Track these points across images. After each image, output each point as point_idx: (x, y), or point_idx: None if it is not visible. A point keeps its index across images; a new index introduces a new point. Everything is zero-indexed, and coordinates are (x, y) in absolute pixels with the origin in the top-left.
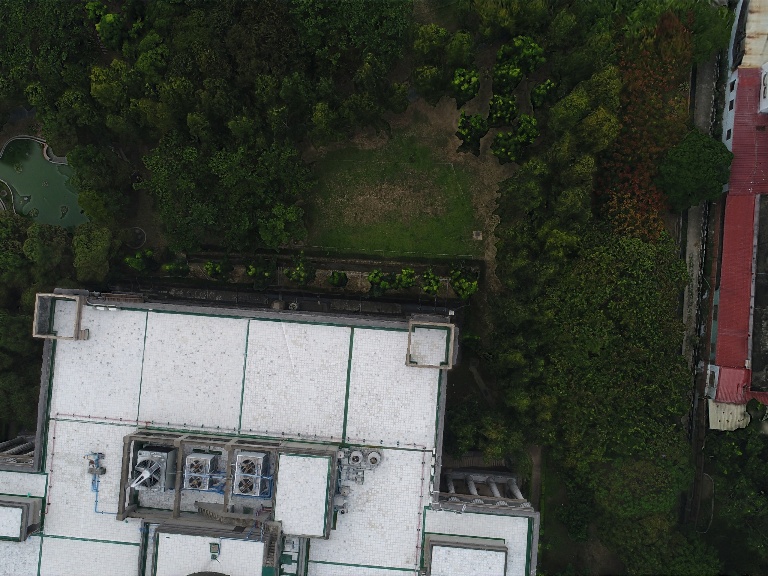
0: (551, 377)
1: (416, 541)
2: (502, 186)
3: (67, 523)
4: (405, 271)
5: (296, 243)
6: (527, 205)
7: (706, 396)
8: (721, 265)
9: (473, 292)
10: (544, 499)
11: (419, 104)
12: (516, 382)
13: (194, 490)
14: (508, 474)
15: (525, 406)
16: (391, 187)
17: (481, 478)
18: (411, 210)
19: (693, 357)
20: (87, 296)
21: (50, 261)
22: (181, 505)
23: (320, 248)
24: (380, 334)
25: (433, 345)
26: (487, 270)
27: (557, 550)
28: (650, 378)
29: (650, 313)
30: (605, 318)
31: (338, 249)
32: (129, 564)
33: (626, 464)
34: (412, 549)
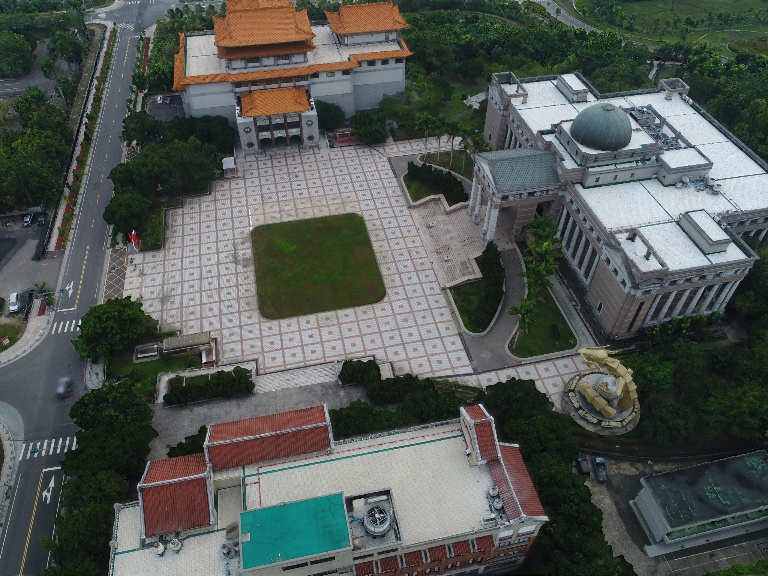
0: None
1: None
2: None
3: None
4: None
5: None
6: None
7: None
8: None
9: None
10: None
11: None
12: None
13: None
14: None
15: None
16: None
17: None
18: None
19: None
20: None
21: None
22: None
23: None
24: None
25: None
26: None
27: None
28: None
29: None
30: None
31: None
32: None
33: None
34: None
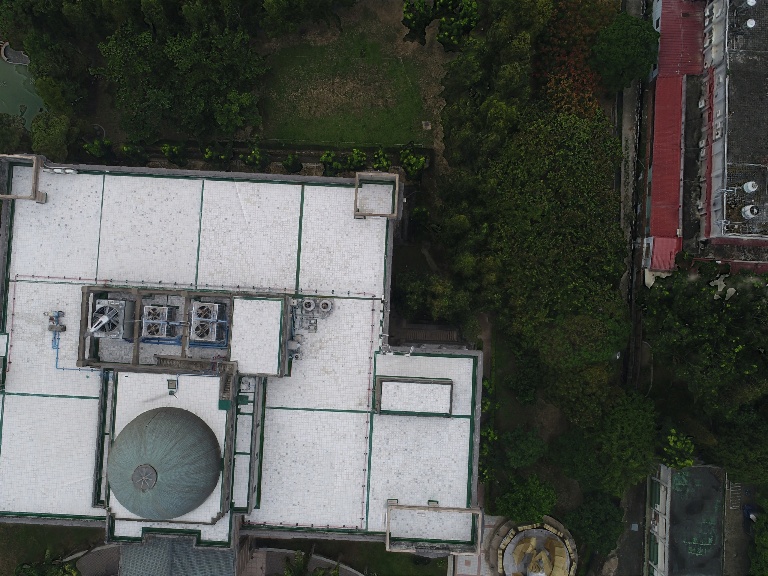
0: (495, 242)
1: (368, 384)
2: (446, 67)
3: (28, 380)
4: (356, 150)
5: (252, 136)
6: (468, 79)
7: (643, 267)
8: (653, 143)
9: (421, 167)
10: (495, 371)
11: (368, 2)
12: (462, 247)
13: (153, 344)
14: (459, 343)
15: (470, 266)
16: (343, 81)
17: (433, 347)
18: (363, 103)
19: (631, 234)
20: (44, 160)
21: (8, 145)
22: (140, 359)
23: (276, 141)
24: (329, 190)
25: (380, 199)
26: (436, 158)
27: (508, 419)
28: (587, 241)
29: (586, 182)
30: (544, 186)
31: (293, 141)
32: (90, 417)
33: (566, 320)
34: (364, 392)
